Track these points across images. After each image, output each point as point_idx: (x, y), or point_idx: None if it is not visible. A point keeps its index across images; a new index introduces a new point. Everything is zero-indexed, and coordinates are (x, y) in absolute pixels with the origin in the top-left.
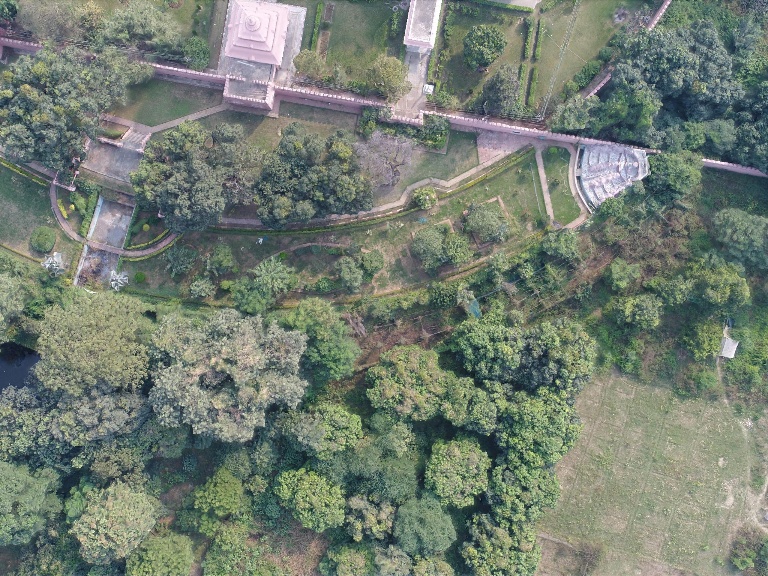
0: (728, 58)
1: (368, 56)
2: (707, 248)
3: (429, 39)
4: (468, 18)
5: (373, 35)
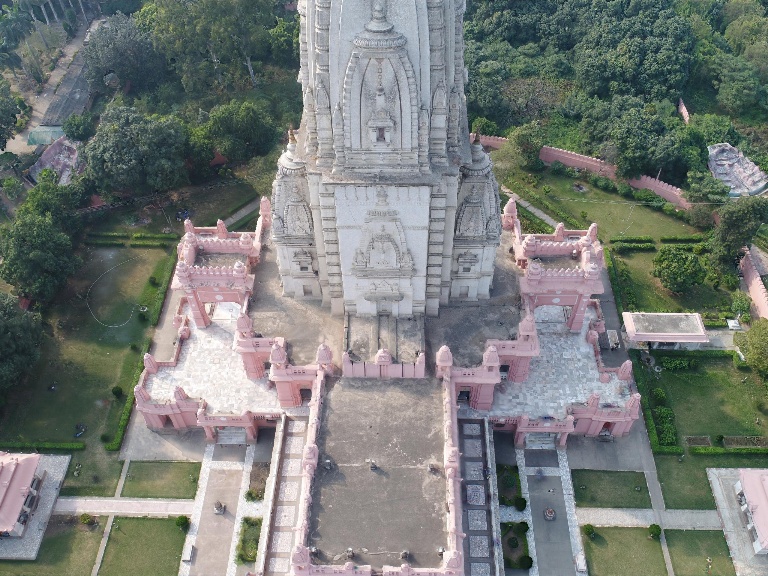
0: (618, 96)
1: (729, 390)
2: (752, 116)
3: (694, 316)
4: (637, 300)
5: (701, 388)
